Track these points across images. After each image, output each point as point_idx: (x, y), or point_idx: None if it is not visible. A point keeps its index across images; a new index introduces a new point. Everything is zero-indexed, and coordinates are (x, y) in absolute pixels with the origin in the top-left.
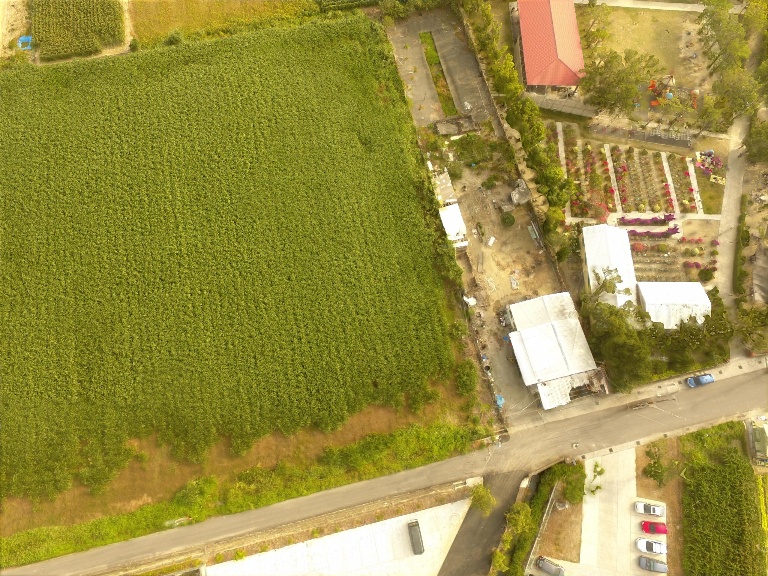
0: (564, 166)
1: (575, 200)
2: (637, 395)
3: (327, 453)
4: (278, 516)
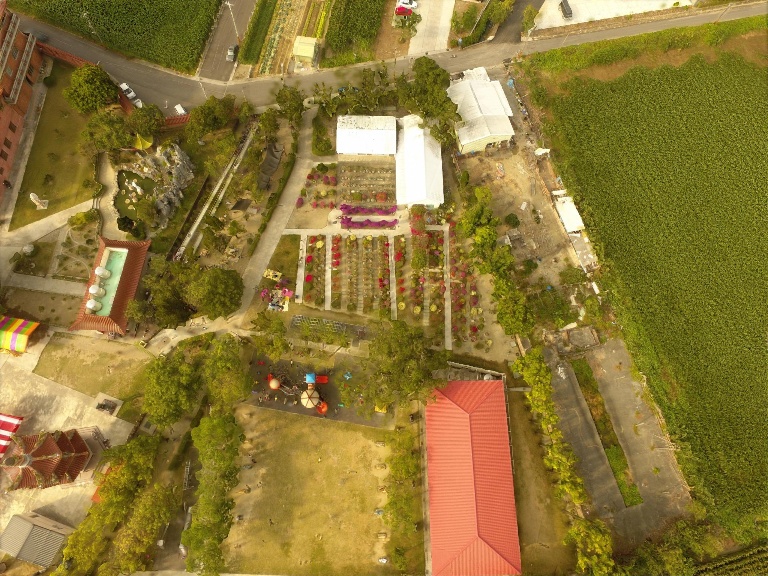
0: (447, 289)
1: None
2: None
3: (637, 51)
4: (656, 26)
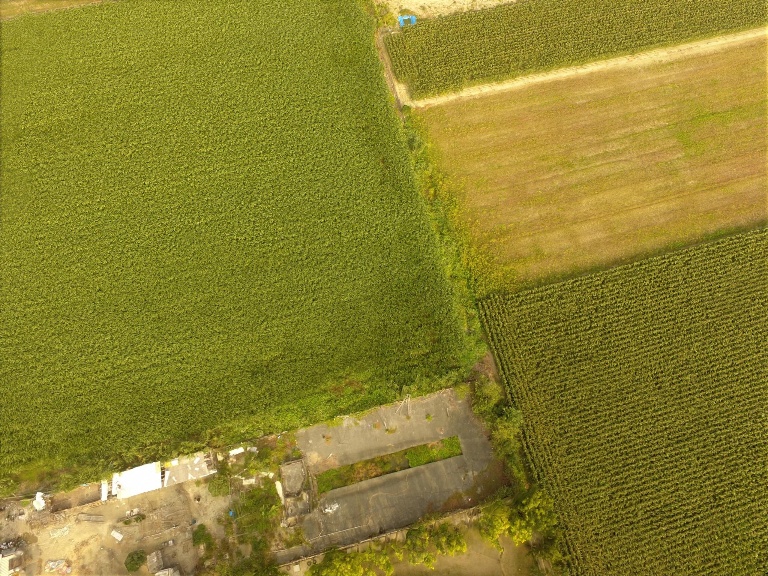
0: None
1: None
2: None
3: None
4: None
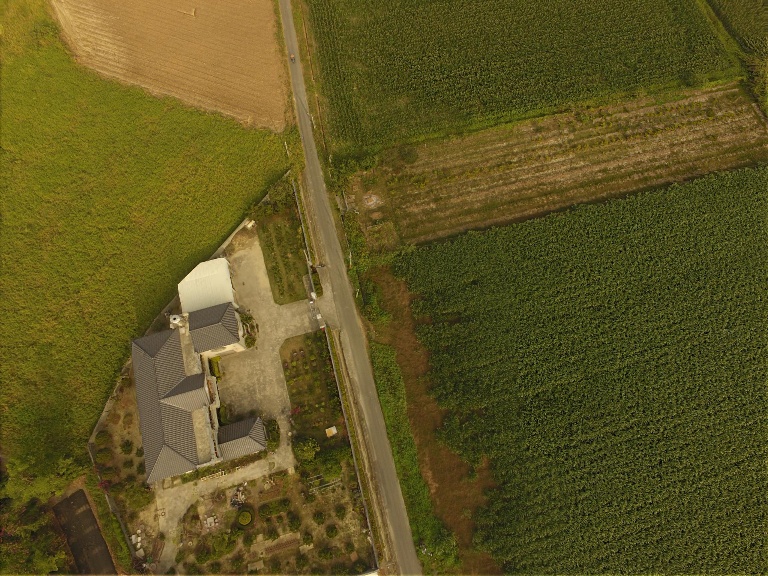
0: None
1: None
2: None
3: None
4: None
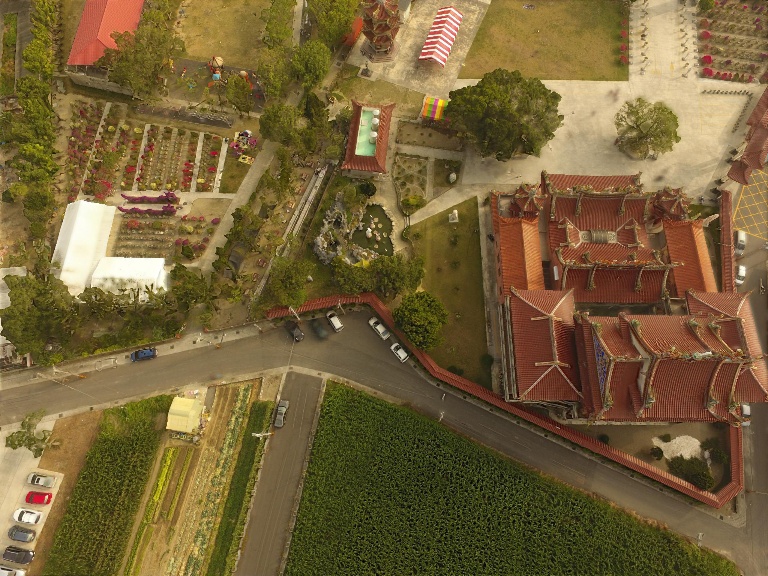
0: None
1: (91, 178)
2: (78, 369)
3: None
4: None
